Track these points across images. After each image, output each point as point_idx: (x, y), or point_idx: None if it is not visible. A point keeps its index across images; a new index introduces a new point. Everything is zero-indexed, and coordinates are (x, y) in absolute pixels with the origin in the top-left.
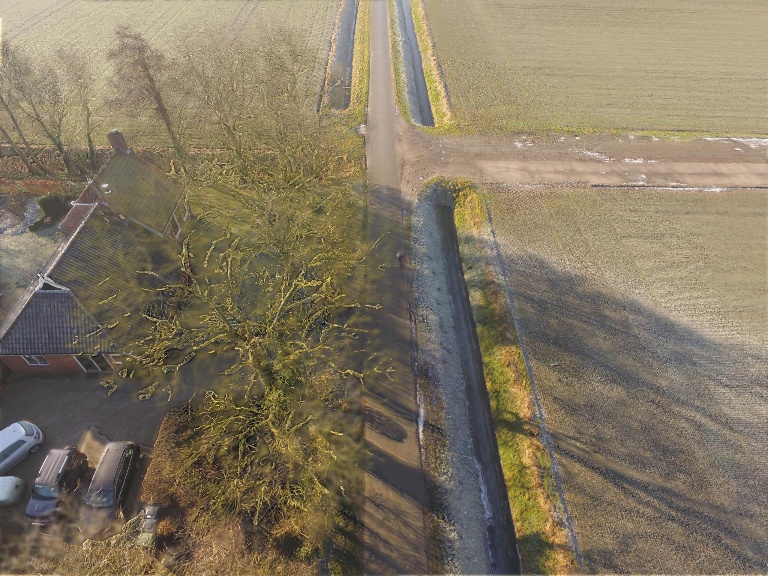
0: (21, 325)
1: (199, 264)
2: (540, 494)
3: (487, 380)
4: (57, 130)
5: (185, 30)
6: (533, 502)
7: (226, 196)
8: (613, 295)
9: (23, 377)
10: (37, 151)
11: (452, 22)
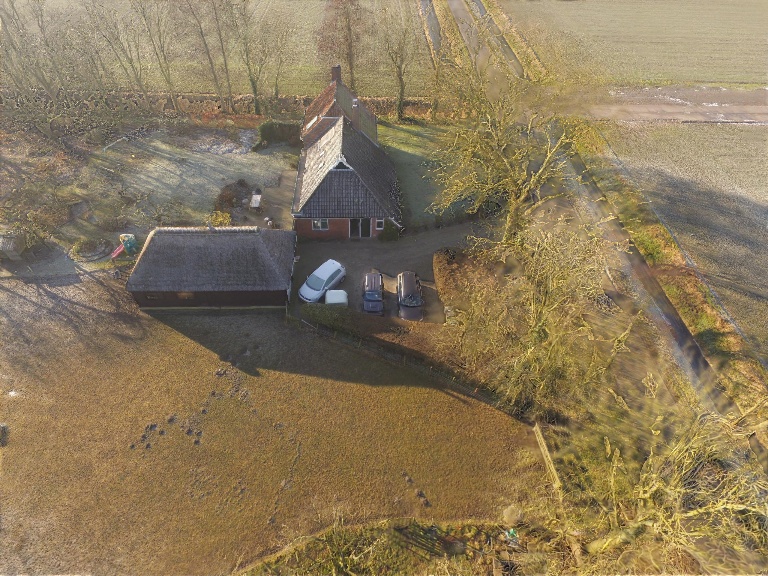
0: (318, 195)
1: (396, 173)
2: (706, 307)
3: (640, 248)
4: (256, 75)
5: (289, 7)
6: (701, 313)
7: (392, 129)
8: (723, 193)
9: (306, 241)
10: (217, 99)
11: (519, 0)
